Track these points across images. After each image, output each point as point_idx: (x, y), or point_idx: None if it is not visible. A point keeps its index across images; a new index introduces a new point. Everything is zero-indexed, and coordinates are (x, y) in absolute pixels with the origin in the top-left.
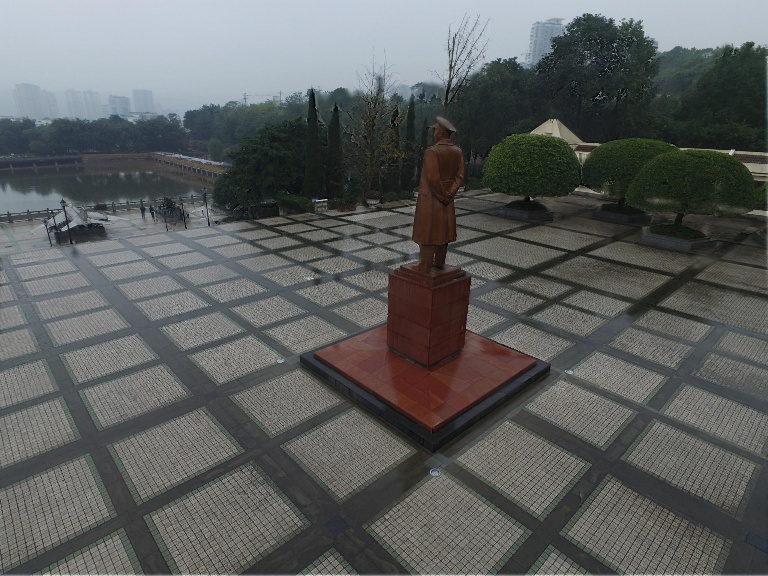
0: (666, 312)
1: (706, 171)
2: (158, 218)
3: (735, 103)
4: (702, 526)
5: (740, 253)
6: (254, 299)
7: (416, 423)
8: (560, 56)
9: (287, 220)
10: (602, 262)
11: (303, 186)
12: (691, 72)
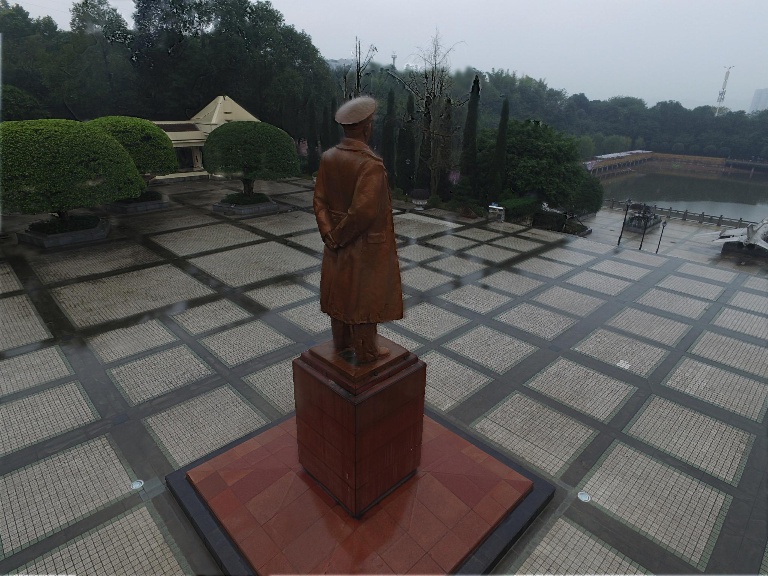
0: None
1: None
2: None
3: None
4: None
5: None
6: (515, 334)
7: None
8: None
9: None
10: None
11: None
12: None
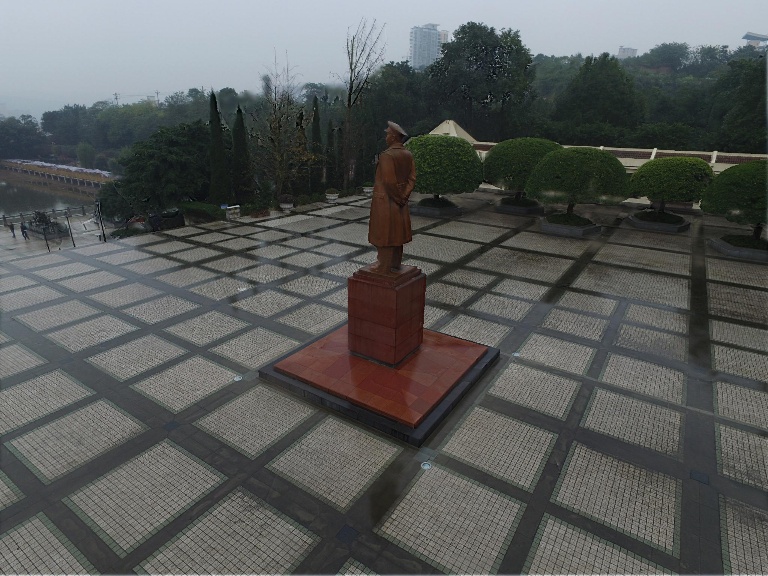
0: (579, 292)
1: (590, 166)
2: (29, 236)
3: (598, 105)
4: (657, 472)
5: (621, 236)
6: (188, 317)
7: (396, 421)
8: (450, 61)
9: (198, 230)
10: (515, 251)
11: (210, 193)
12: (561, 78)
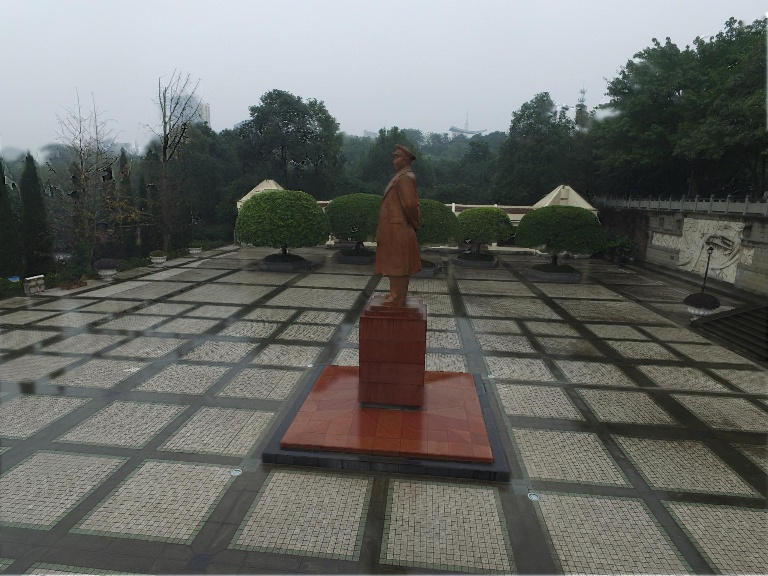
0: (479, 318)
1: (434, 214)
2: None
3: None
4: (682, 440)
5: (460, 273)
6: (82, 416)
7: (470, 462)
8: (263, 123)
9: None
10: None
11: None
12: (363, 145)
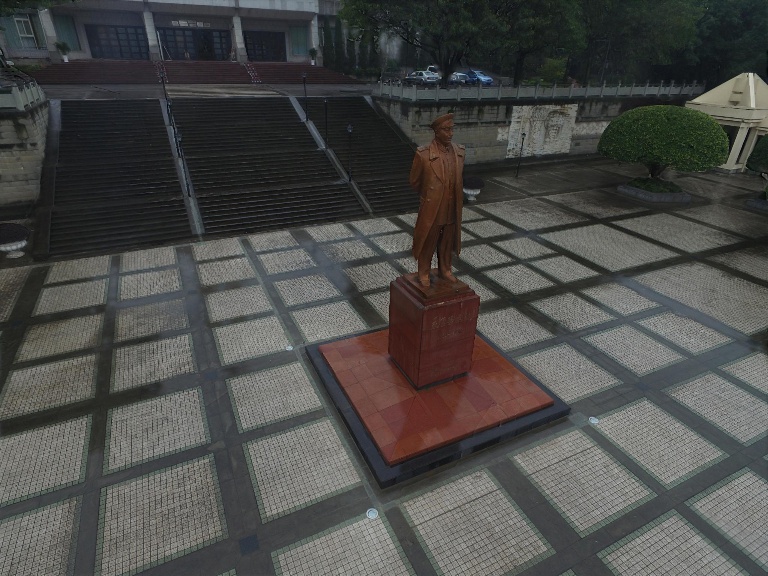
0: None
1: None
2: None
3: None
4: None
5: None
6: None
7: None
8: None
9: None
10: None
11: None
12: None
